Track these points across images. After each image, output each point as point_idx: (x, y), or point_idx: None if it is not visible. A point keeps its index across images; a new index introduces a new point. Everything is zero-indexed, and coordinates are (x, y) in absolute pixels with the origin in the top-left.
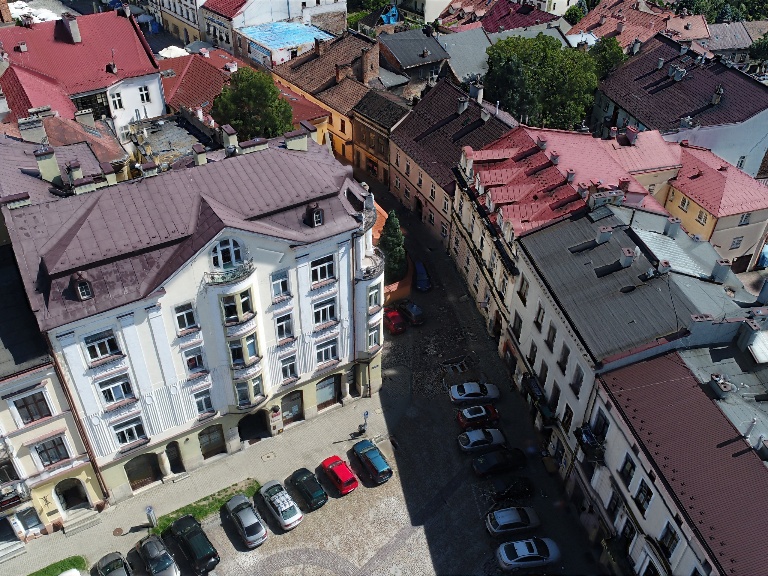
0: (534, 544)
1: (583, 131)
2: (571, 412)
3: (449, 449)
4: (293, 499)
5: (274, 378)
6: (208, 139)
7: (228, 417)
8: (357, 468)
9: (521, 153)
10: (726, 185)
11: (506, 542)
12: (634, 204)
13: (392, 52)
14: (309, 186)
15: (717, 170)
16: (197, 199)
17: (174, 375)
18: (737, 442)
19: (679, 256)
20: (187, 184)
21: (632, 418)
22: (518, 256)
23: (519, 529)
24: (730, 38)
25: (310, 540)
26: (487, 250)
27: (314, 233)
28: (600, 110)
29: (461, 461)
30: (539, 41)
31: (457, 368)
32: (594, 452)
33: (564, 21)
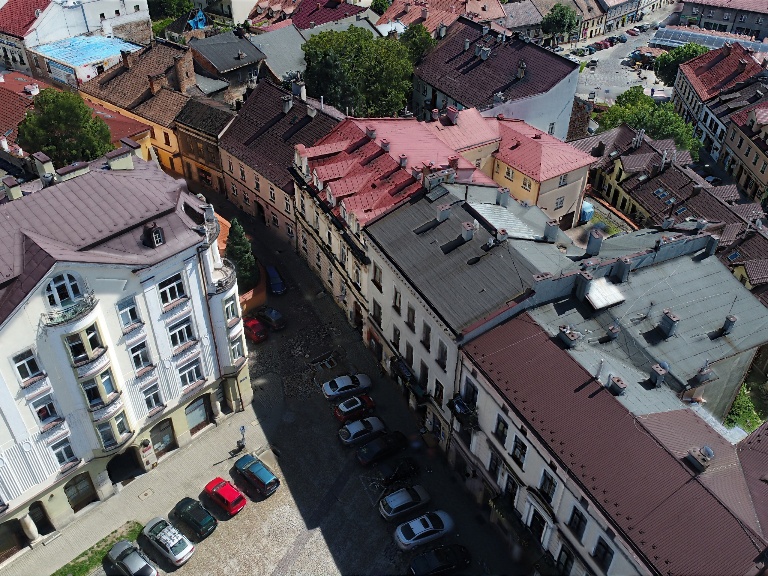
0: (428, 519)
1: (407, 116)
2: (441, 386)
3: (332, 446)
4: (180, 532)
5: (138, 411)
6: (18, 170)
7: (94, 462)
8: (242, 485)
9: (353, 145)
10: (542, 151)
11: (402, 524)
12: (465, 180)
13: (206, 57)
14: (142, 206)
15: (532, 139)
16: (18, 237)
17: (24, 430)
18: (591, 384)
19: (513, 223)
20: (3, 222)
21: (497, 381)
22: (367, 245)
23: (412, 508)
24: (523, 16)
25: (206, 570)
26: (336, 244)
27: (156, 254)
28: (419, 94)
29: (345, 455)
30: (351, 33)
31: (326, 365)
32: (468, 420)
33: (371, 12)
